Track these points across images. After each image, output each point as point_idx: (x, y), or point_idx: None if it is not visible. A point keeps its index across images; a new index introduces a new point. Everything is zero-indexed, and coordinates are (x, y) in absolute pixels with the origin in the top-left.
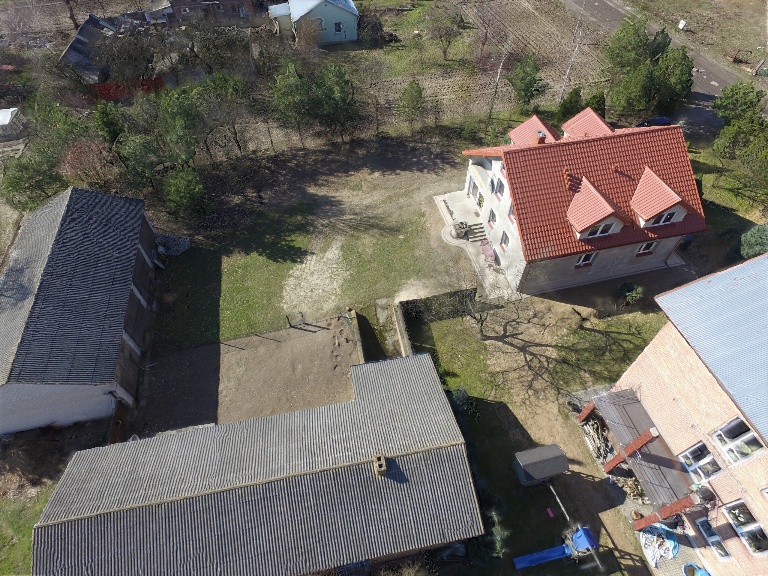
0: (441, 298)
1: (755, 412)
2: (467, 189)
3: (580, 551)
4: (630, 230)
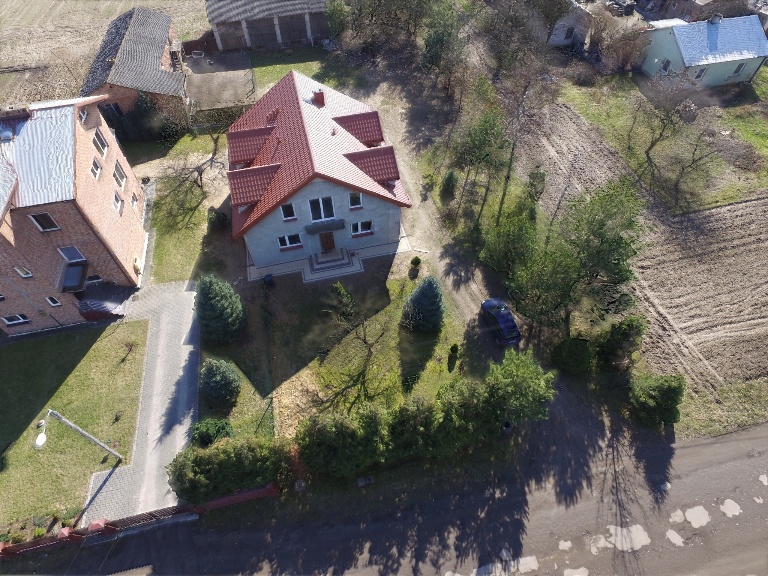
0: None
1: None
2: None
3: None
4: None
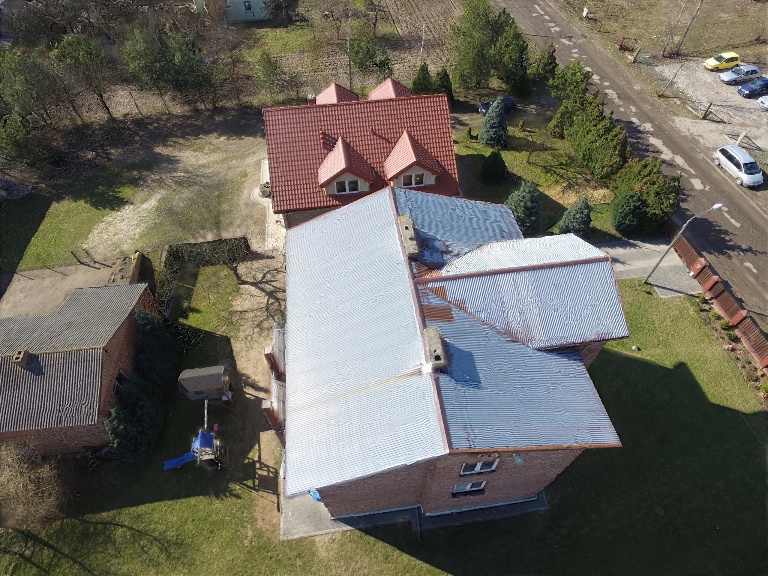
0: (211, 245)
1: (292, 323)
2: None
3: (194, 451)
4: None
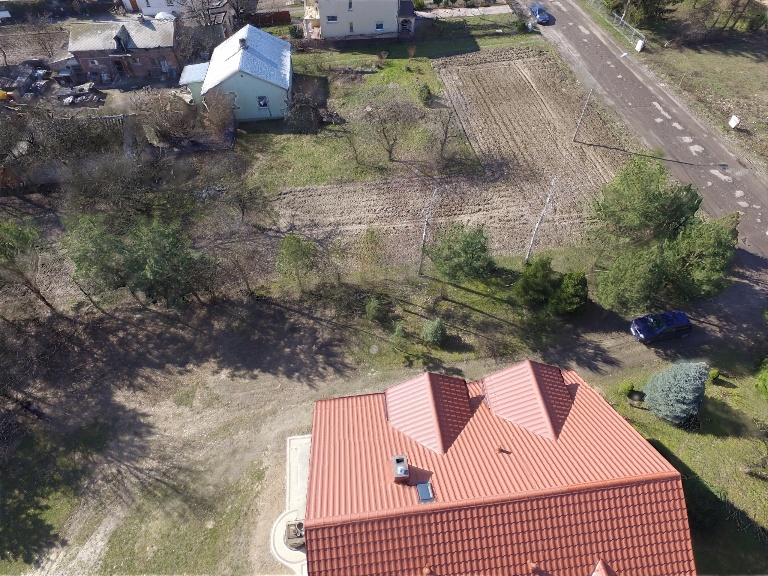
0: None
1: None
2: None
3: None
4: None
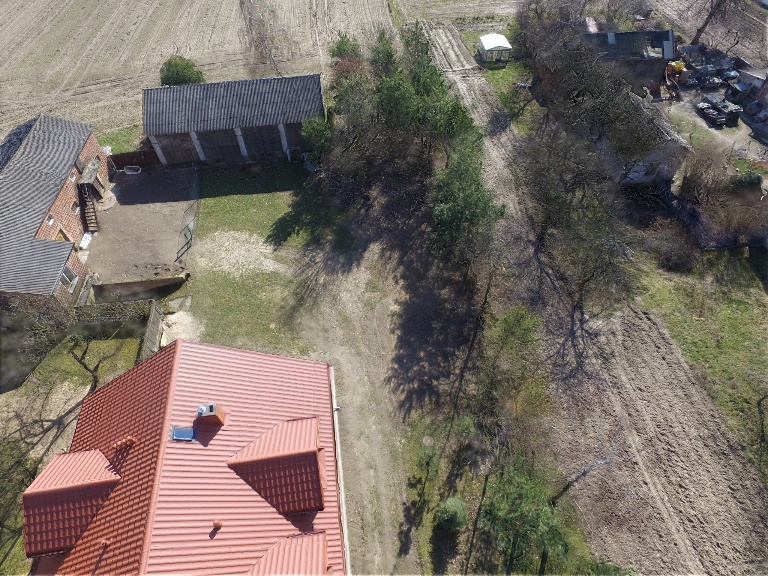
0: None
1: None
2: None
3: None
4: (46, 570)
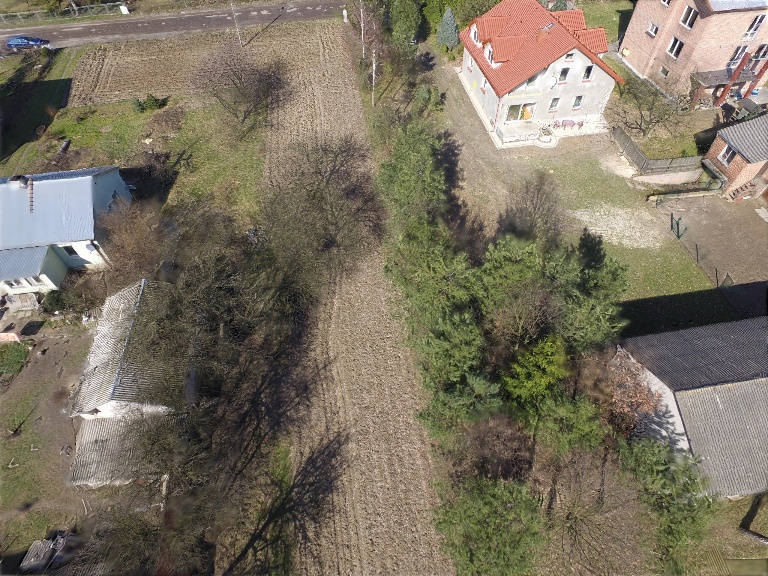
0: None
1: None
2: (504, 121)
3: None
4: None
